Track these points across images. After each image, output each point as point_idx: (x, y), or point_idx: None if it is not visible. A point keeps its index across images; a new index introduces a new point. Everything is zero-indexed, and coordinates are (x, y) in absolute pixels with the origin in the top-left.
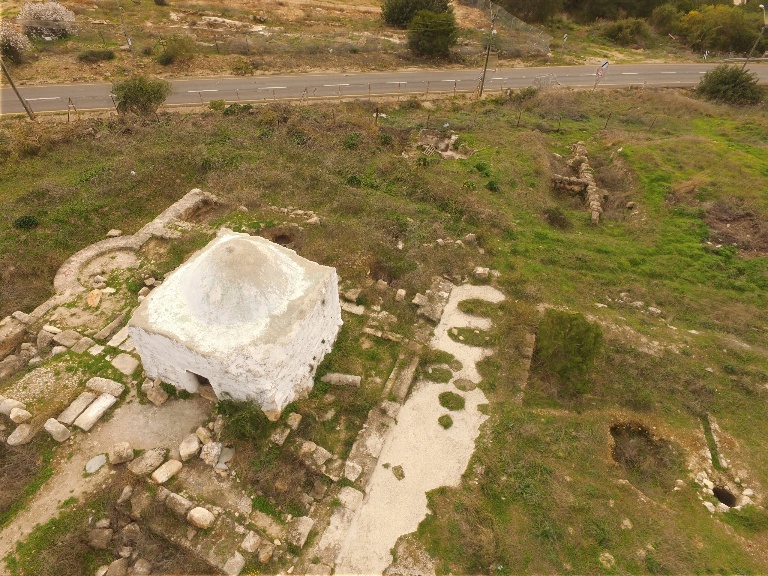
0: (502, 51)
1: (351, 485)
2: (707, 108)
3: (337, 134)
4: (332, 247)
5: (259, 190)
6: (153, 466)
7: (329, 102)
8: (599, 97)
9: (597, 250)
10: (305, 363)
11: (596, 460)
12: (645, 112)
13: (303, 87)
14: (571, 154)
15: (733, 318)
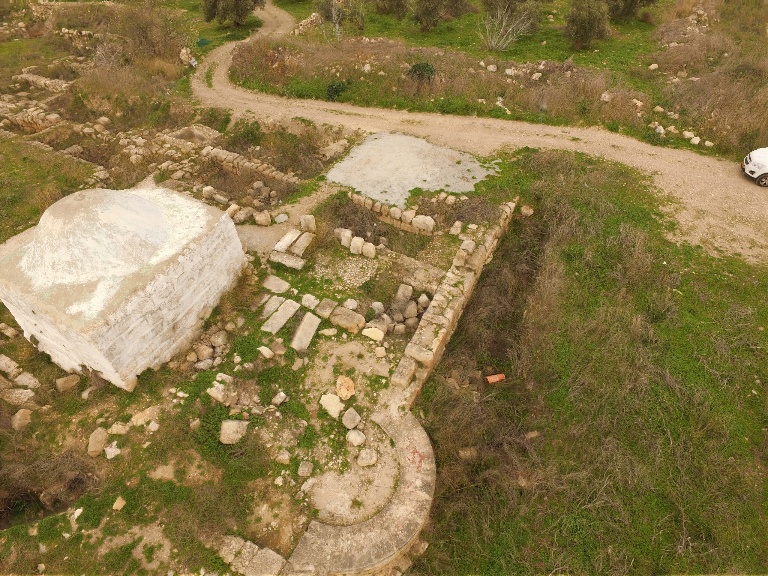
0: None
1: None
2: None
3: None
4: None
5: None
6: None
7: None
8: None
9: None
10: None
11: None
12: None
13: None
14: None
15: None
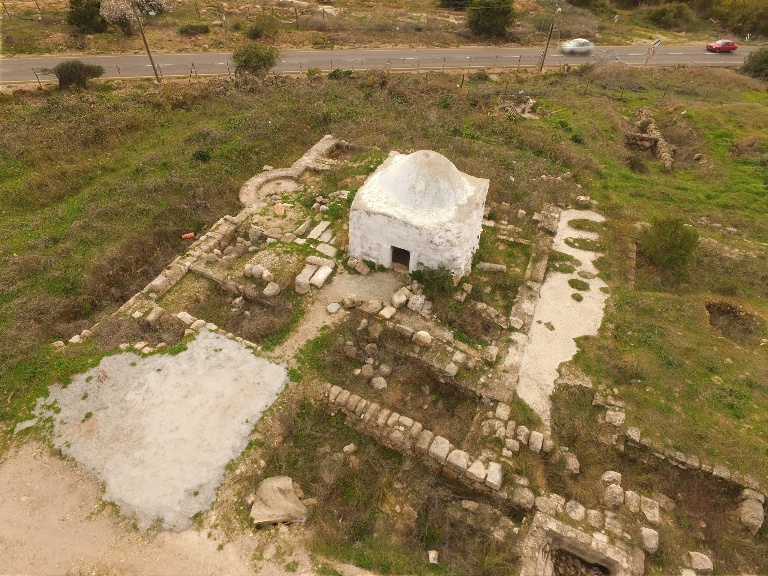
0: None
1: (517, 331)
2: (754, 83)
3: (431, 96)
4: None
5: None
6: (377, 309)
7: None
8: (649, 74)
9: (676, 187)
10: (470, 249)
11: (699, 324)
12: (699, 84)
13: (387, 58)
14: (637, 118)
15: None
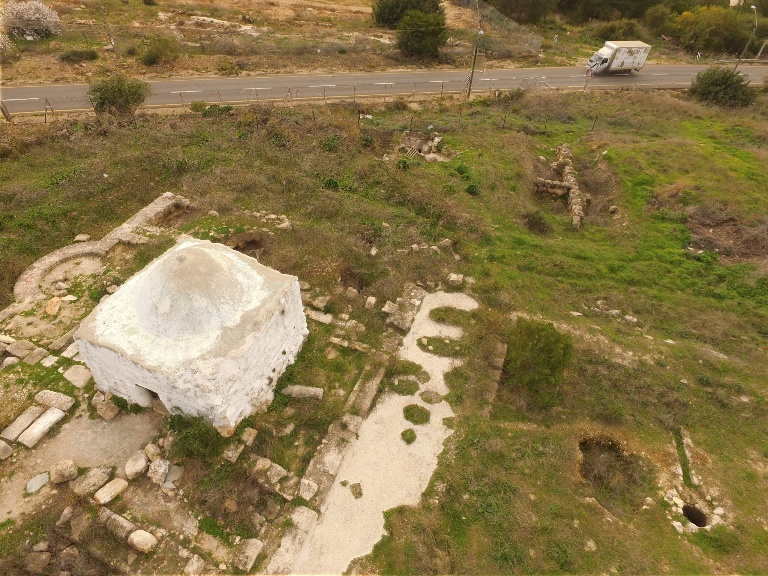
0: (493, 52)
1: (305, 504)
2: (697, 110)
3: (317, 136)
4: (301, 253)
5: (233, 194)
6: (96, 485)
7: (314, 103)
8: (589, 98)
9: (576, 256)
10: (263, 376)
11: (563, 477)
12: (633, 114)
13: (287, 88)
14: (556, 157)
15: (711, 327)
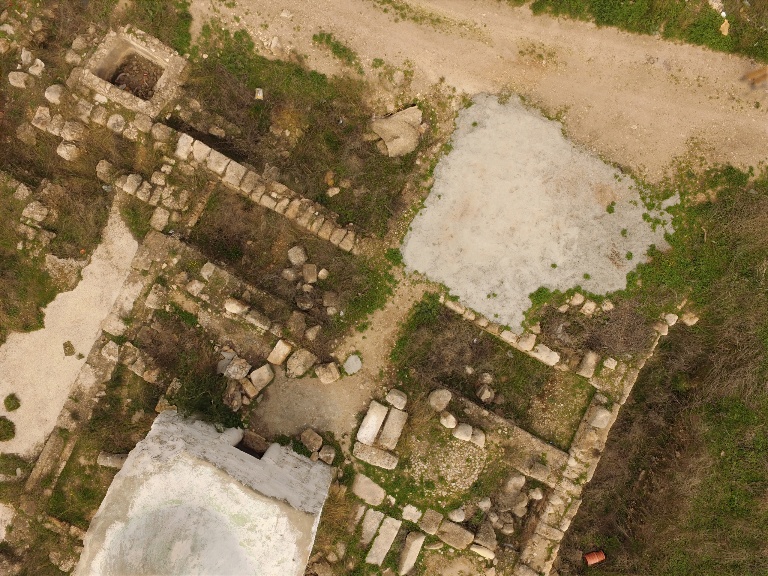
0: None
1: (113, 337)
2: None
3: None
4: None
5: None
6: (292, 357)
7: None
8: None
9: None
10: None
11: None
12: None
13: None
14: None
15: None
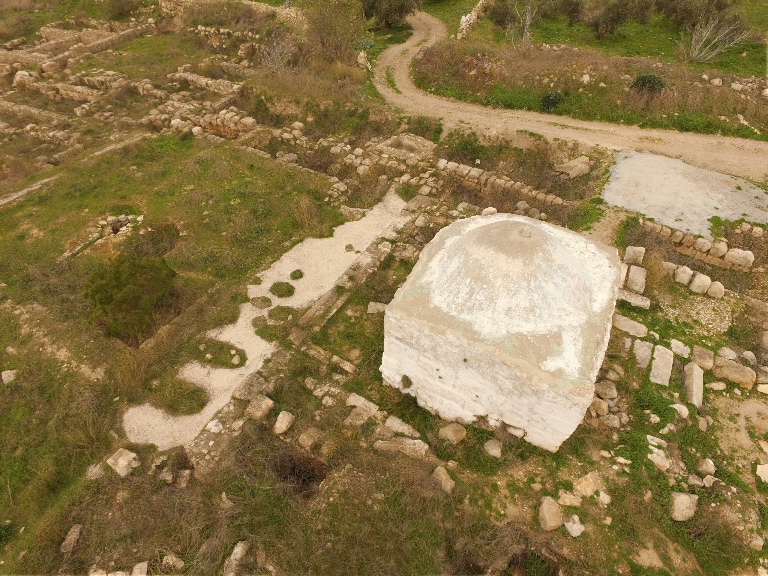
0: None
1: (387, 240)
2: None
3: None
4: (387, 494)
5: None
6: None
7: None
8: None
9: None
10: None
11: None
12: None
13: None
14: None
15: None
